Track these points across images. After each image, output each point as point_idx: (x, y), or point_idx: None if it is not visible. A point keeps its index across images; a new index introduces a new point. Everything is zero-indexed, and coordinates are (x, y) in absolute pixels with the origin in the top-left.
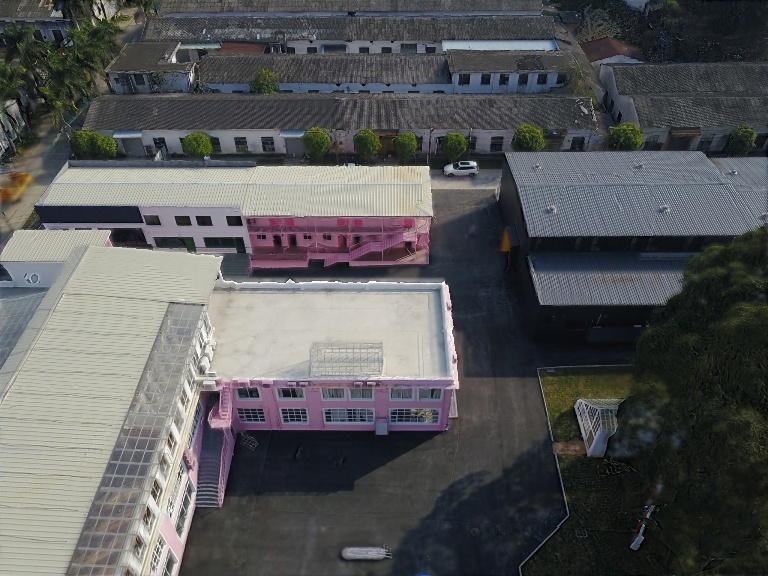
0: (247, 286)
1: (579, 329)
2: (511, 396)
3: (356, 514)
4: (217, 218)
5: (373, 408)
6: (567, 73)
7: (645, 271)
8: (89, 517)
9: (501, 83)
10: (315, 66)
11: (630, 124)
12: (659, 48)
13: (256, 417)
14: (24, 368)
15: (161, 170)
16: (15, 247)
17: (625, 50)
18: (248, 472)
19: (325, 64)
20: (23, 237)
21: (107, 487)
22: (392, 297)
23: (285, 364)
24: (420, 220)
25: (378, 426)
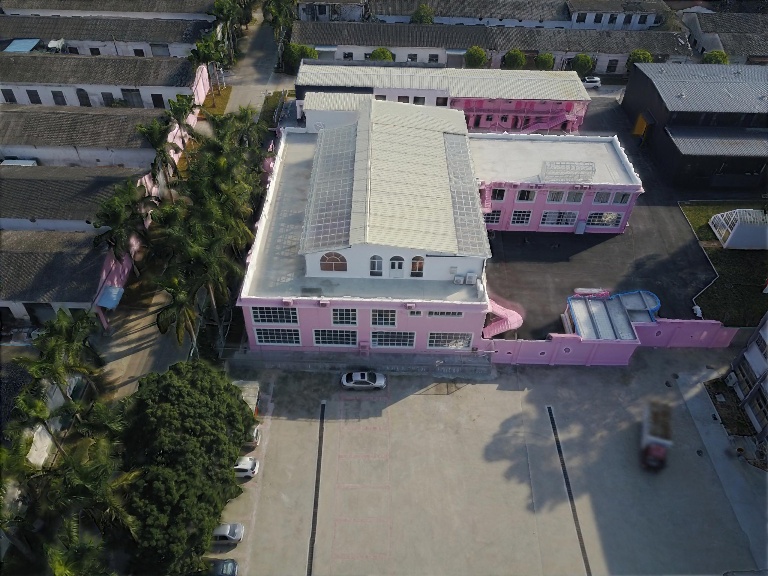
0: (474, 136)
1: (705, 177)
2: (663, 216)
3: (576, 273)
4: (429, 99)
5: (578, 211)
6: (663, 15)
7: (751, 138)
8: (456, 227)
9: (610, 22)
10: (461, 4)
11: (719, 51)
12: (725, 4)
13: (493, 219)
14: (373, 158)
15: (375, 68)
16: (312, 102)
17: (701, 3)
18: (494, 251)
19: (469, 3)
20: (314, 96)
21: (457, 215)
22: (579, 145)
23: (521, 177)
24: (580, 105)
25: (579, 226)
